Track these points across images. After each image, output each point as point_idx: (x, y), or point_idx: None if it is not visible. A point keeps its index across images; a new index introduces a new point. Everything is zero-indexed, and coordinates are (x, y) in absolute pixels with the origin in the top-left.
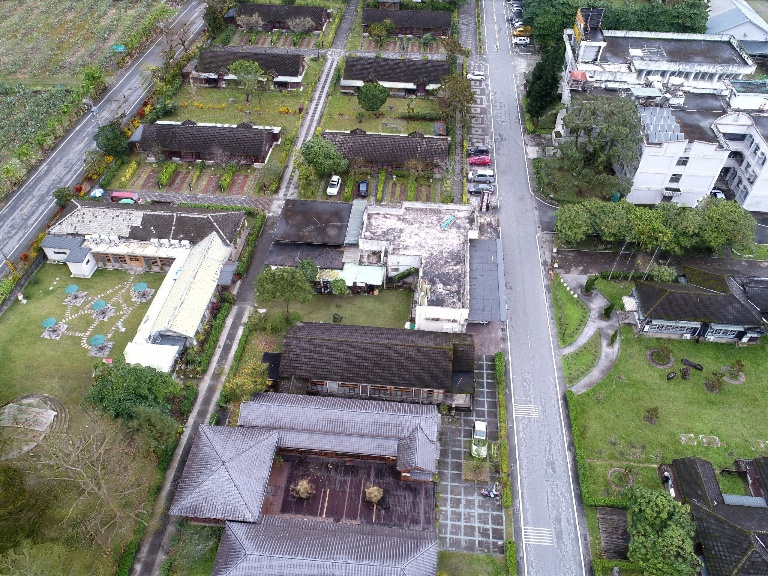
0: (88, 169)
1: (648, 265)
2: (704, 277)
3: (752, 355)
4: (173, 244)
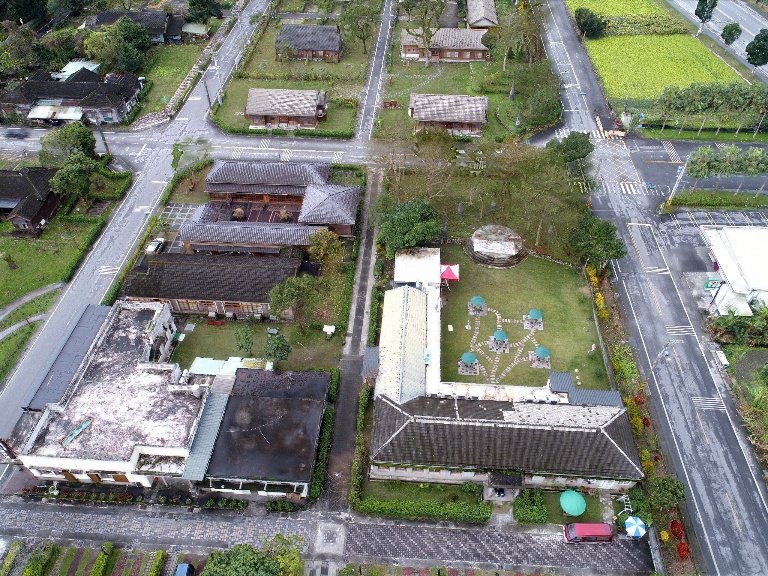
0: None
1: None
2: None
3: None
4: None
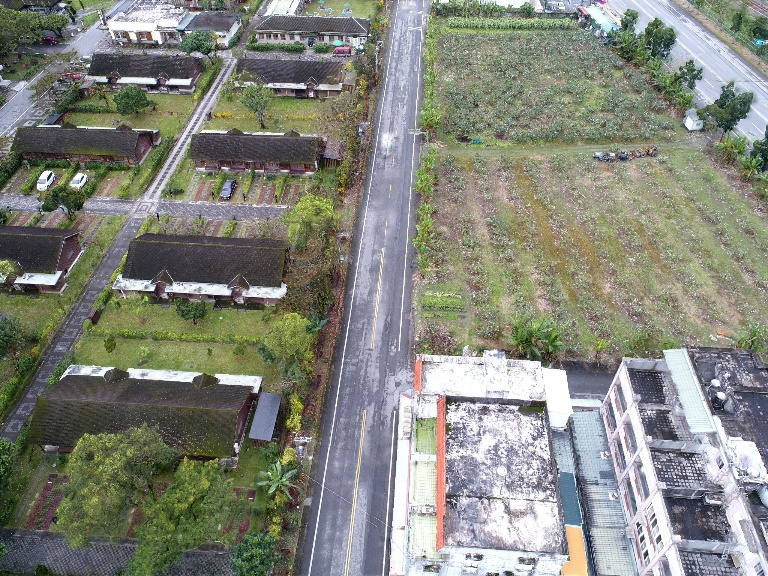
0: None
1: None
2: (16, 1)
3: None
4: None
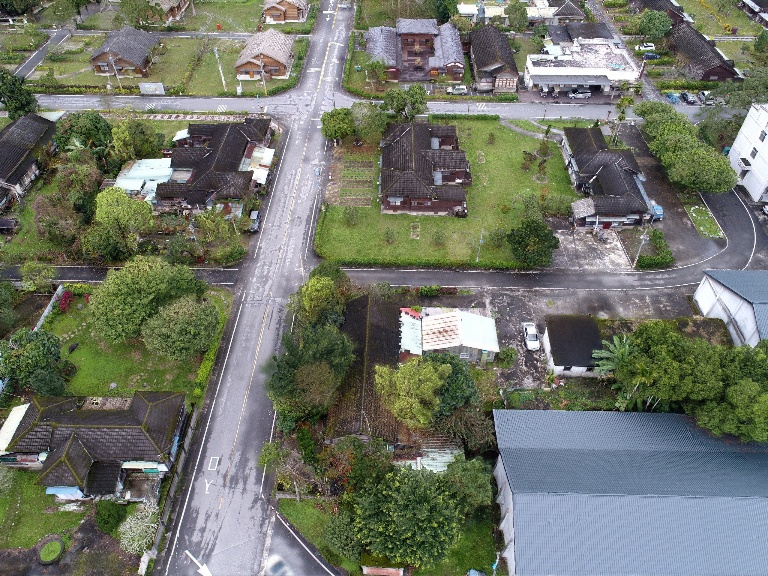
0: None
1: (643, 161)
2: None
3: (564, 190)
4: None
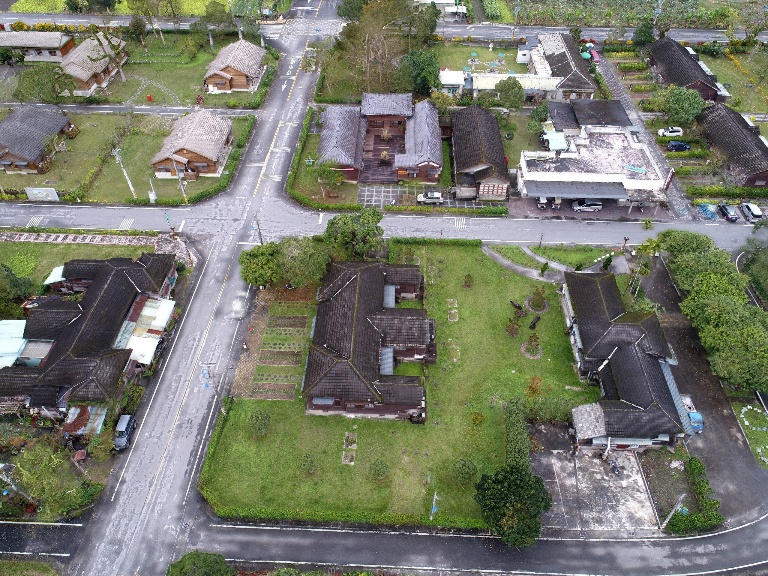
0: (608, 35)
1: (672, 320)
2: (637, 317)
3: (563, 372)
4: (547, 70)
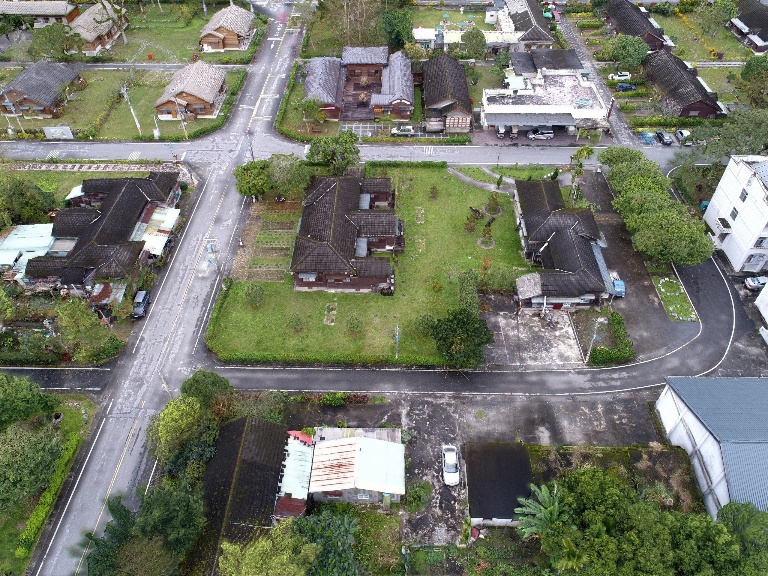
0: None
1: (607, 219)
2: (574, 210)
3: (512, 257)
4: None
